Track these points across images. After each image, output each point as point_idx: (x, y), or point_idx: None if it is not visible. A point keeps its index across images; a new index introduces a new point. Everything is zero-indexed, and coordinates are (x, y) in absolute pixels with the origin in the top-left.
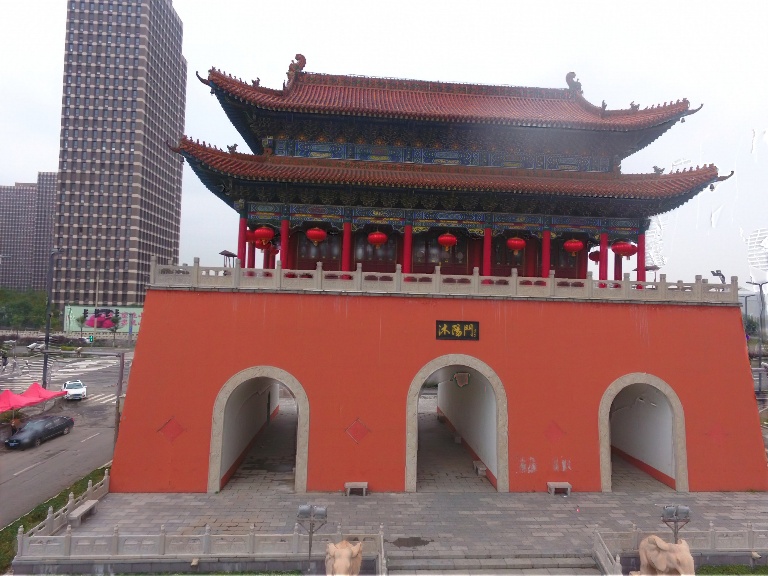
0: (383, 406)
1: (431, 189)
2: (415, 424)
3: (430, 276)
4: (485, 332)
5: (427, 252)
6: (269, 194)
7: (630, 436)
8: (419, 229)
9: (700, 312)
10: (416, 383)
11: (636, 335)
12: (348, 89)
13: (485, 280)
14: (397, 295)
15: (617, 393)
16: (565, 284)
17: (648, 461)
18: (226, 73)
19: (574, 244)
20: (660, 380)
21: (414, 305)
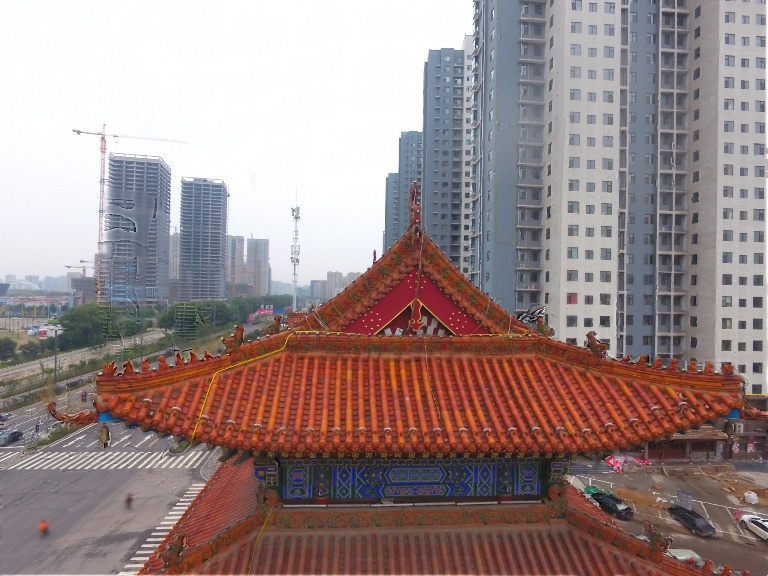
0: None
1: None
2: None
3: None
4: None
5: None
6: None
7: None
8: None
9: None
10: None
11: None
12: None
13: None
14: None
15: None
16: None
17: None
18: (690, 365)
19: None
20: None
21: None
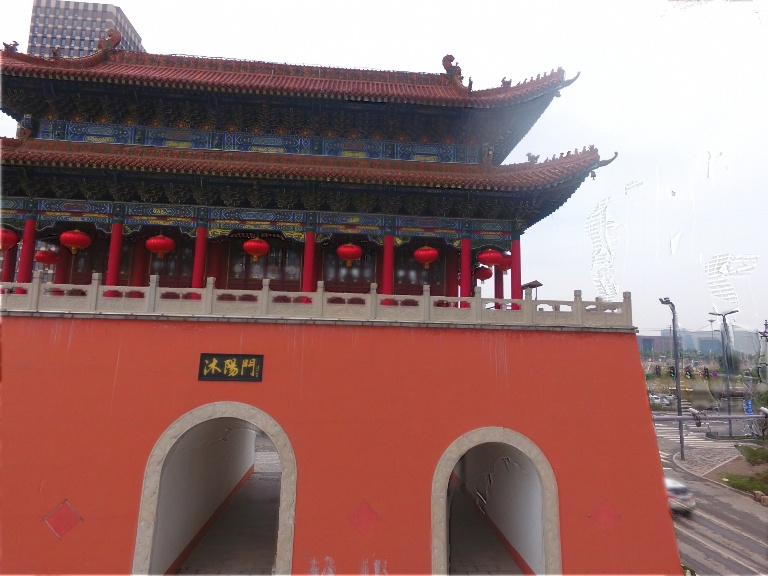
0: (108, 480)
1: (218, 177)
2: (153, 507)
3: (199, 291)
4: (272, 370)
5: (248, 265)
6: (8, 185)
7: (508, 513)
8: (216, 232)
9: (580, 340)
10: (162, 445)
11: (490, 373)
12: (170, 70)
13: (278, 297)
14: (146, 317)
15: (460, 457)
16: (392, 302)
17: (522, 552)
18: None
19: (424, 252)
20: (523, 437)
21: (171, 331)
